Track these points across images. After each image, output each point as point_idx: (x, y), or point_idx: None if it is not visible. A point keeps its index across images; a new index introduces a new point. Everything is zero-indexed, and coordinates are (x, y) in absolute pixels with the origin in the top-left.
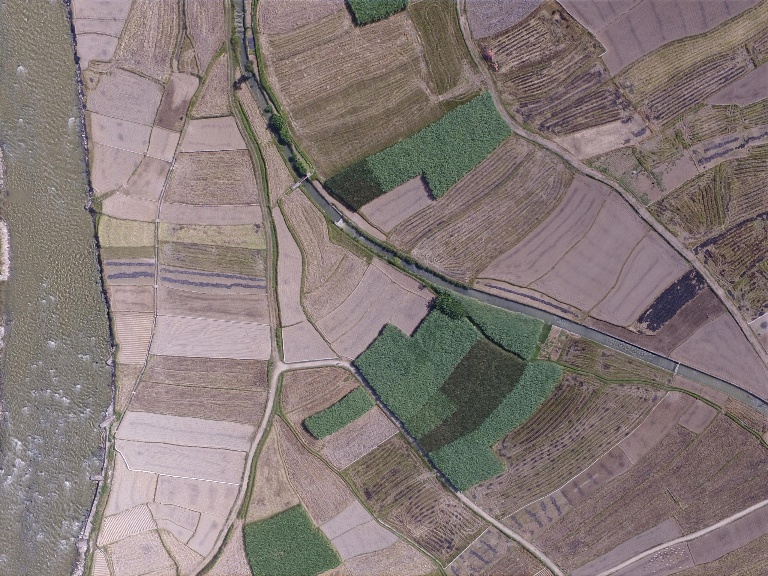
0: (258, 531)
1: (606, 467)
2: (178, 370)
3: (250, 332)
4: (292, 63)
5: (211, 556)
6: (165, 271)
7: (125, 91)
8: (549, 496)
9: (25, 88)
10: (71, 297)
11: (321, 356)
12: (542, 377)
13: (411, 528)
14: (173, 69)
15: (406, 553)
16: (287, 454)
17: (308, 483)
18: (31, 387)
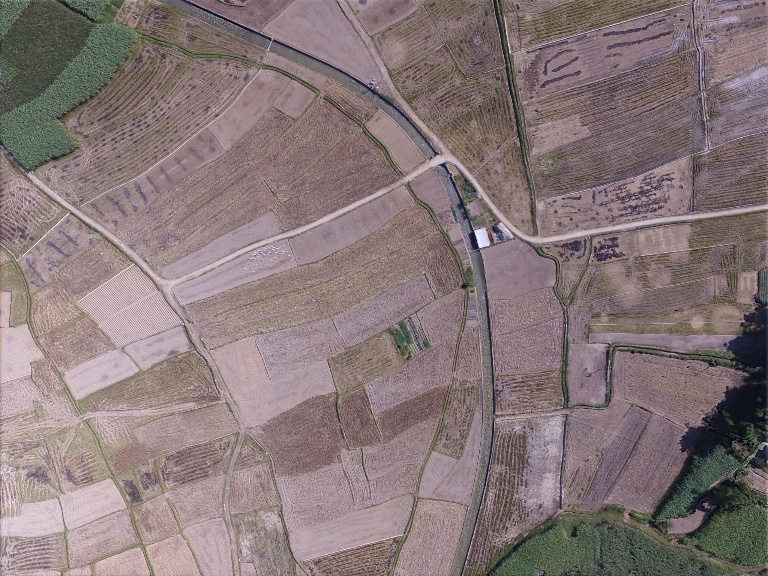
0: None
1: (195, 152)
2: None
3: None
4: None
5: None
6: None
7: None
8: (133, 182)
9: None
10: None
11: None
12: (111, 40)
13: None
14: None
15: None
16: None
17: None
18: None
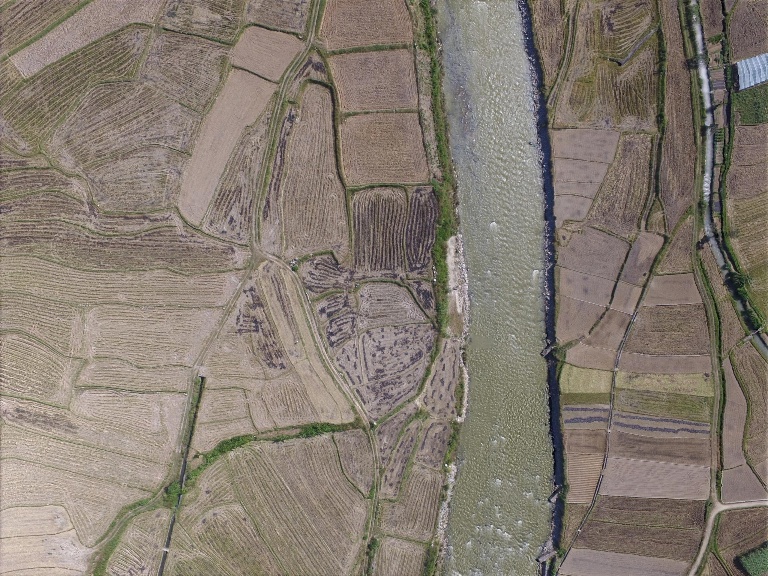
0: None
1: None
2: (622, 509)
3: (692, 474)
4: (753, 225)
5: None
6: (618, 416)
7: (593, 248)
8: None
9: (496, 242)
10: (521, 438)
11: (756, 497)
12: None
13: None
14: (641, 229)
15: None
16: None
17: None
18: (476, 523)
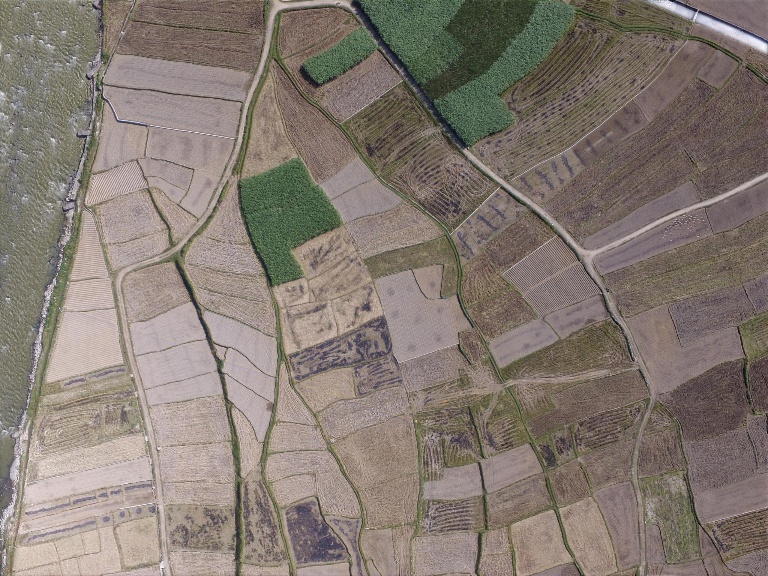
0: (254, 183)
1: (621, 124)
2: (169, 9)
3: None
4: None
5: (205, 218)
6: None
7: None
8: (561, 155)
9: None
10: None
11: None
12: (554, 16)
13: (415, 189)
14: None
15: (410, 216)
16: (285, 104)
17: (307, 137)
18: (14, 31)
